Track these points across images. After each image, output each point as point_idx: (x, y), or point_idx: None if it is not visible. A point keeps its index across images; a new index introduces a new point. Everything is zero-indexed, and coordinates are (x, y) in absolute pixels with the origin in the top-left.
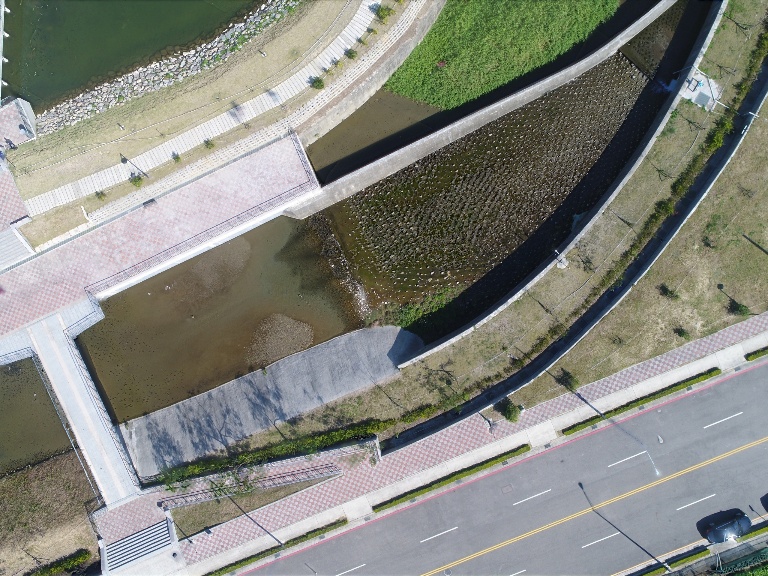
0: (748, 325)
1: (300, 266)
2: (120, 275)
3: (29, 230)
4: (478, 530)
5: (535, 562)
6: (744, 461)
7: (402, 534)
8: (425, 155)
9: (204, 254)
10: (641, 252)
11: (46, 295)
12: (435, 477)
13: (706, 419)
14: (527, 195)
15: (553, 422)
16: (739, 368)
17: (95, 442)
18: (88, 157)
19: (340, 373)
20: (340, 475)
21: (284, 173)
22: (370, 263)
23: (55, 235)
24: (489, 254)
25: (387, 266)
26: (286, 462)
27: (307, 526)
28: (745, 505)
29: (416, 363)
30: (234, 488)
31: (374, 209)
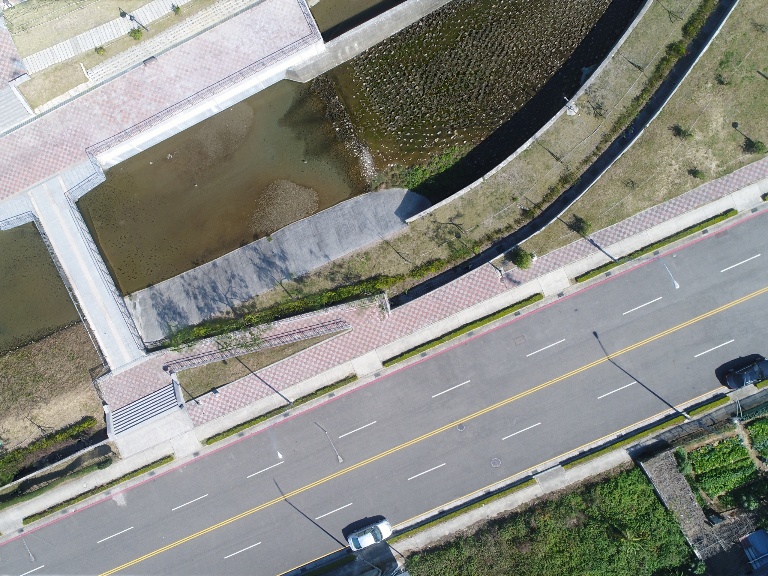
0: (764, 164)
1: (304, 131)
2: (121, 135)
3: (28, 89)
4: (491, 383)
5: (550, 414)
6: (763, 305)
7: (413, 389)
8: (429, 12)
9: (206, 121)
10: (653, 95)
11: (46, 157)
12: (446, 330)
13: (723, 262)
14: (534, 49)
15: (566, 270)
16: (756, 209)
17: (99, 306)
18: (86, 12)
19: (347, 232)
20: (349, 330)
21: (286, 26)
22: (375, 125)
23: (54, 95)
24: (496, 111)
25: (393, 128)
26: (293, 319)
27: (316, 384)
28: (765, 350)
29: (424, 216)
30: (241, 348)
31: (378, 69)
